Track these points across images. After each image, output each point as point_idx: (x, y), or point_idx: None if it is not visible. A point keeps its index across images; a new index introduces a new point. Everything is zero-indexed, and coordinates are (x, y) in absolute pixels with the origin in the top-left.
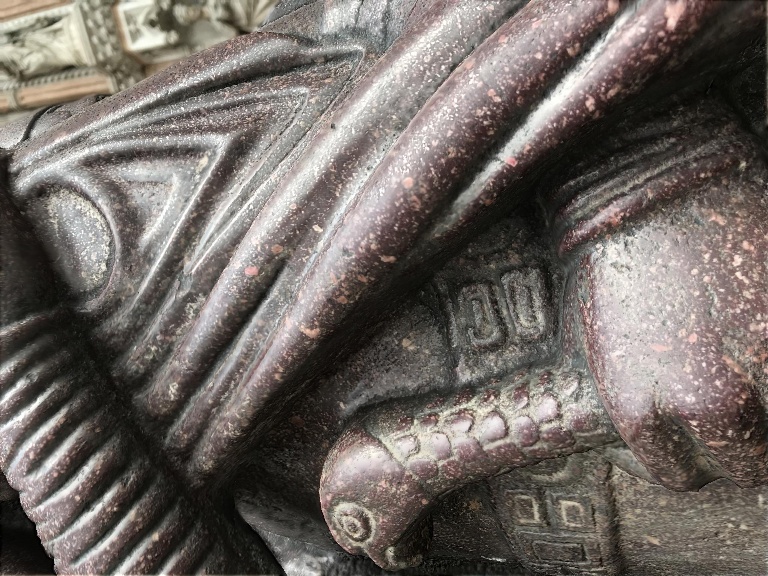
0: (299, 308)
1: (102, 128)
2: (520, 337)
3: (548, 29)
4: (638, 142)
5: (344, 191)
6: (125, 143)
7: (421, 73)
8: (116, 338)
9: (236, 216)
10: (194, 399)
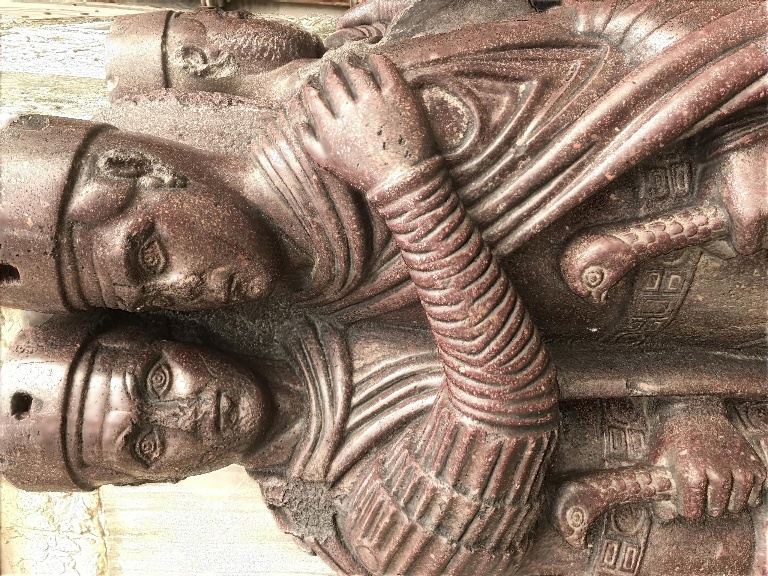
0: (607, 165)
1: (462, 57)
2: (676, 195)
3: (752, 63)
4: (754, 113)
5: (635, 113)
6: (480, 68)
7: (683, 68)
8: (463, 177)
9: (553, 119)
10: (509, 214)
